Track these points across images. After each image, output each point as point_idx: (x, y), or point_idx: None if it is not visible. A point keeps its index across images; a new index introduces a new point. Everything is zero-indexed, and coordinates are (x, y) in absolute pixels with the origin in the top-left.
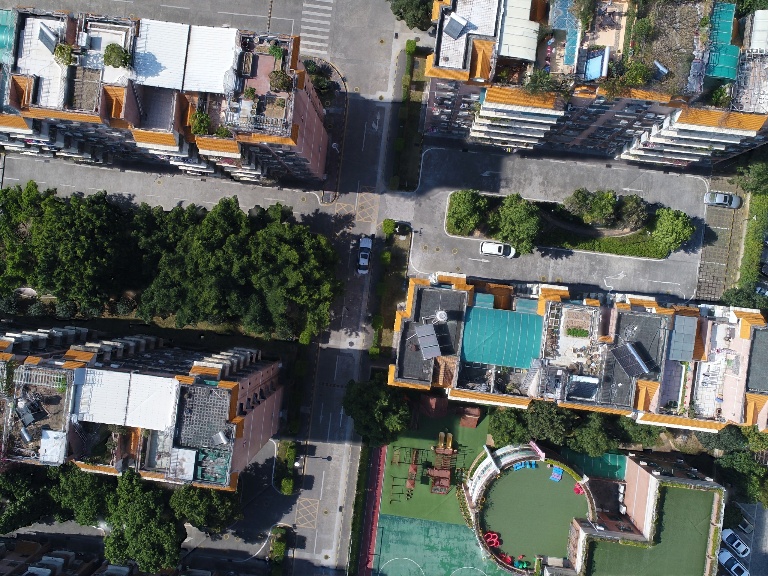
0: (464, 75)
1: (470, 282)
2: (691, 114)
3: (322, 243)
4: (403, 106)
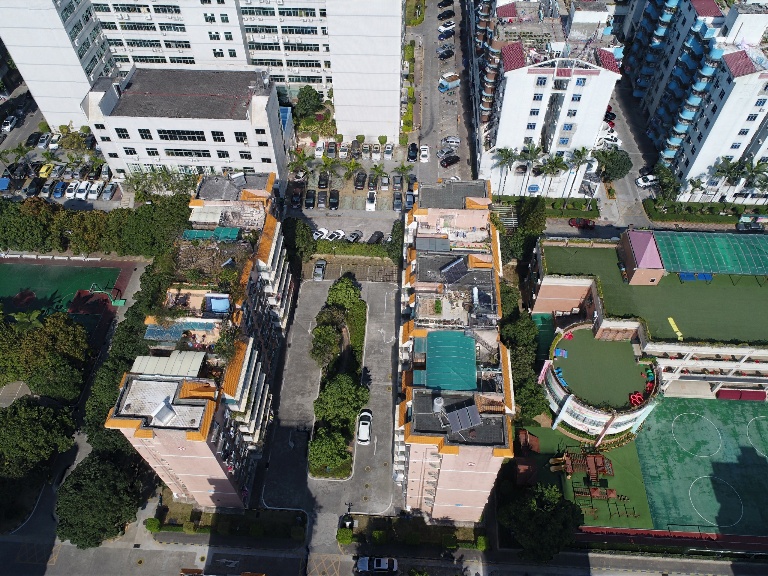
0: (211, 405)
1: None
2: (262, 254)
3: None
4: (215, 531)
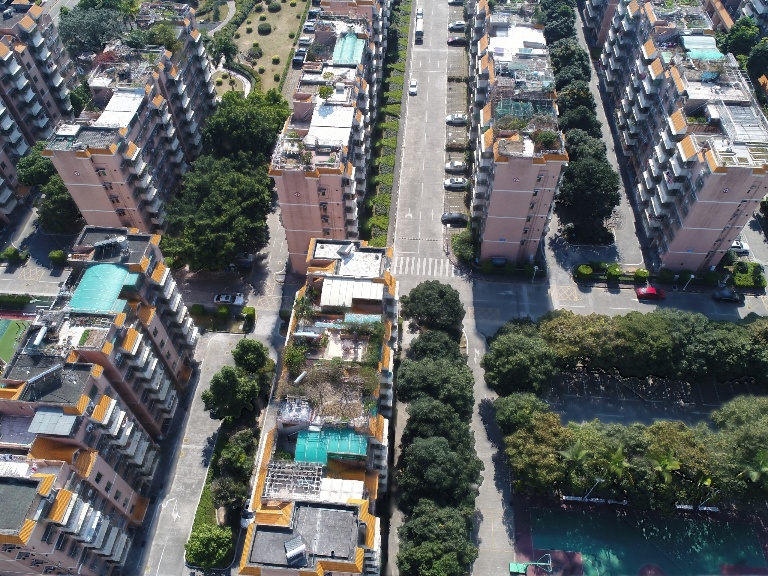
0: None
1: (189, 367)
2: None
3: (227, 243)
4: None
